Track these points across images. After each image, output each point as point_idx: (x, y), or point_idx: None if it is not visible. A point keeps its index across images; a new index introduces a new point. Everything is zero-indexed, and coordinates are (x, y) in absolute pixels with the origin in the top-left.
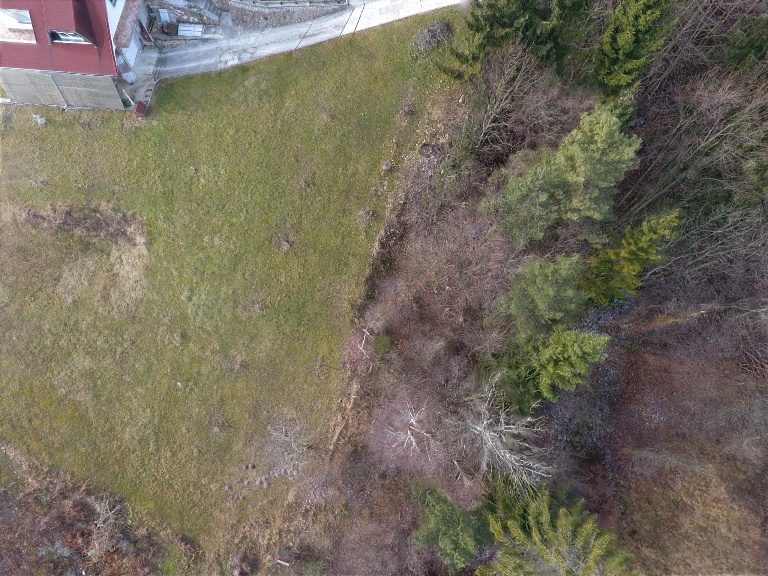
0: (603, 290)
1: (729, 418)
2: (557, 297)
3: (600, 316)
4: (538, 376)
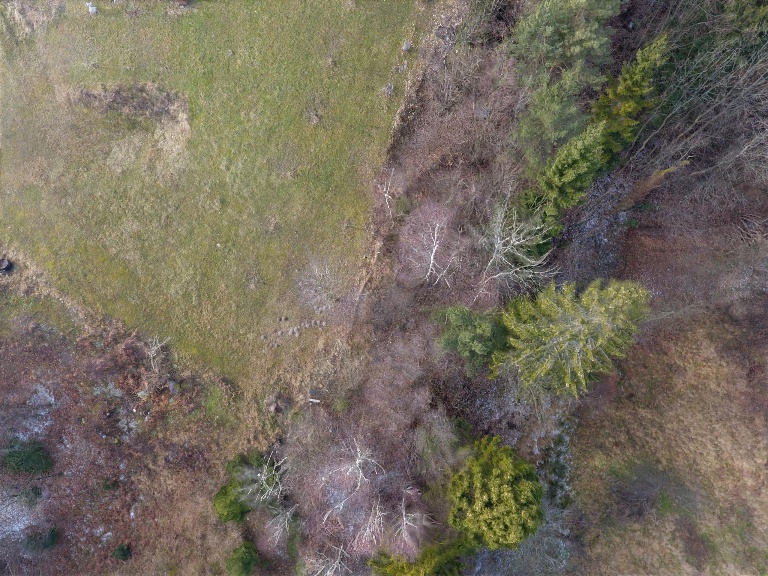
0: (602, 144)
1: (718, 287)
2: (562, 117)
3: (600, 205)
4: (545, 205)
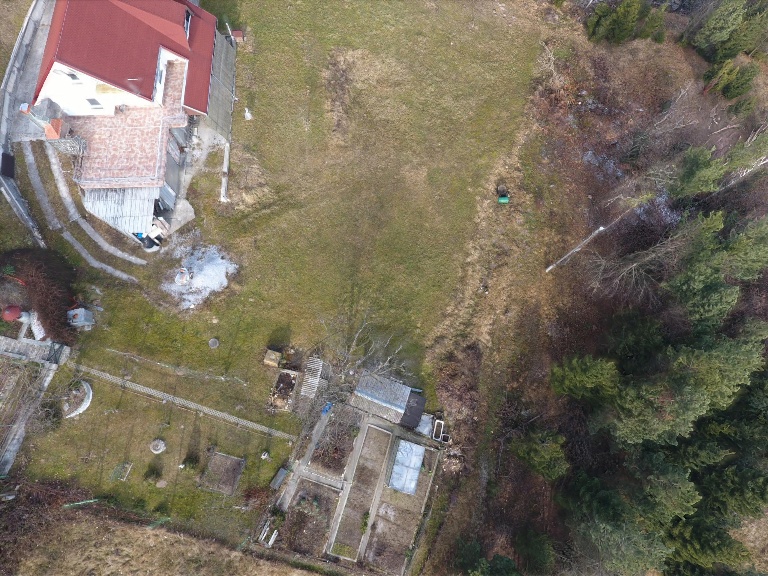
0: None
1: None
2: None
3: None
4: None
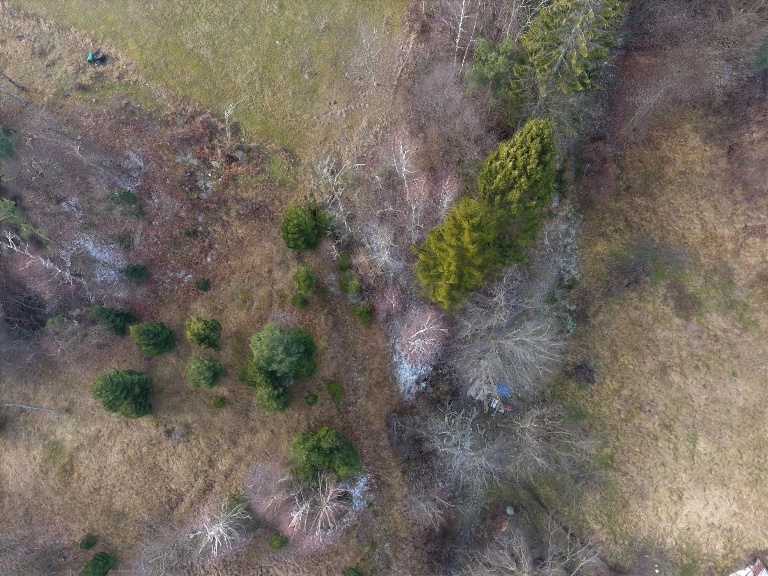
0: None
1: (703, 88)
2: None
3: None
4: None
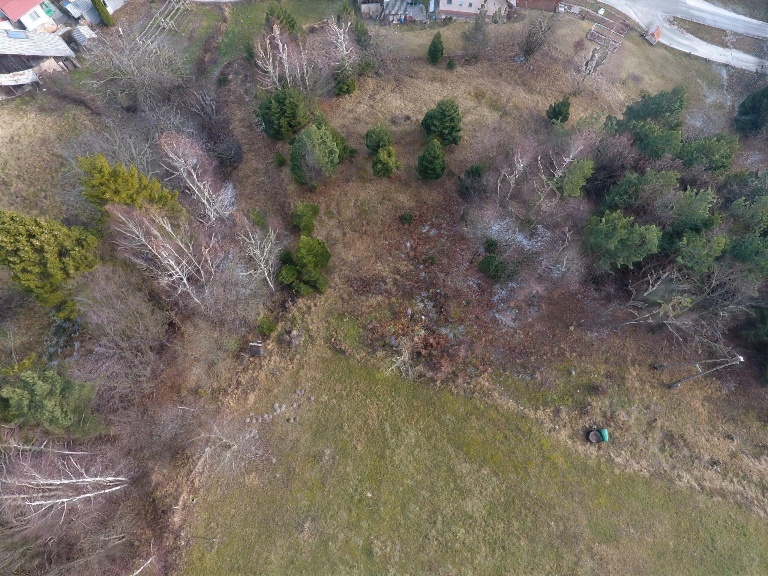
0: None
1: None
2: None
3: None
4: None
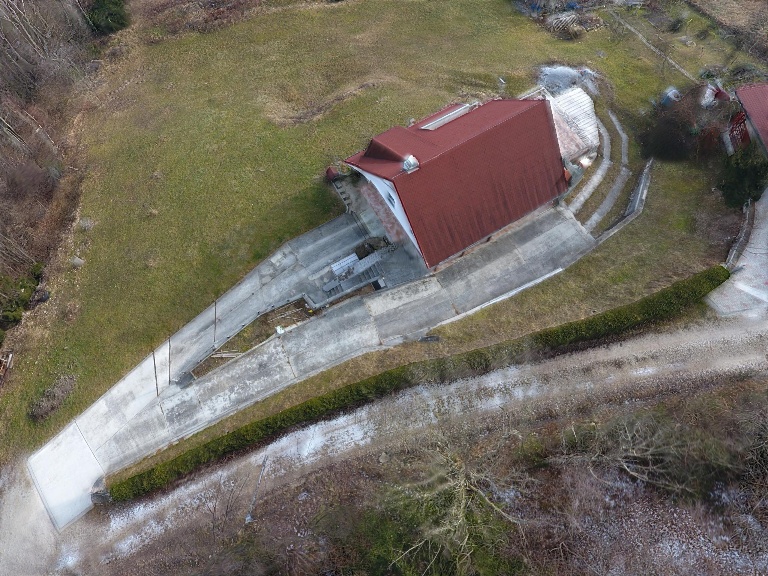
0: None
1: None
2: None
3: None
4: None
